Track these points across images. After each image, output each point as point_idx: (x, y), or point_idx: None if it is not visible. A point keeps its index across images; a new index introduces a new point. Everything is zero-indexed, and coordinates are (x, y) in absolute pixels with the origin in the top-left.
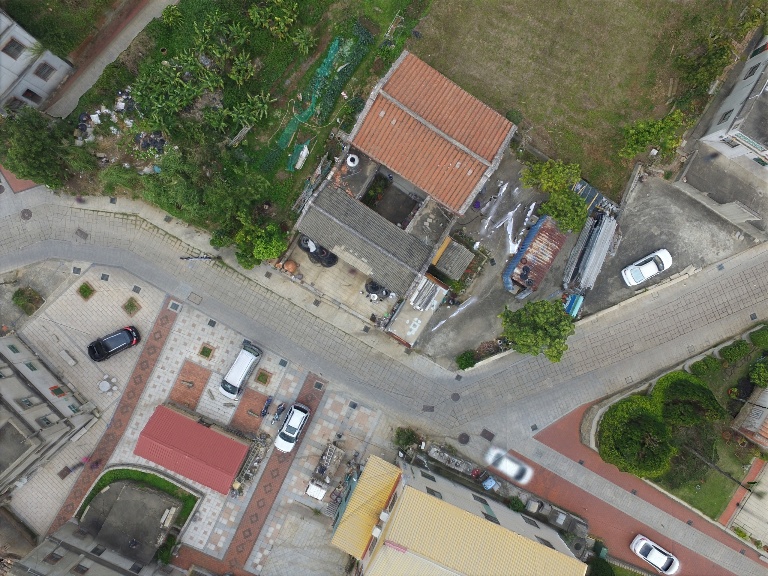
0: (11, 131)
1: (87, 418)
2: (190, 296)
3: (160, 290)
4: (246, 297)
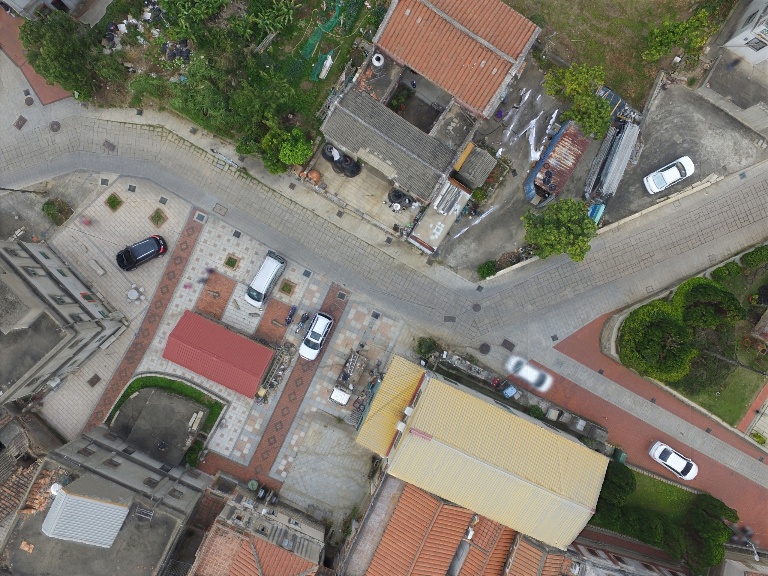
0: (43, 30)
1: (116, 324)
2: (215, 207)
3: (186, 201)
4: (270, 208)
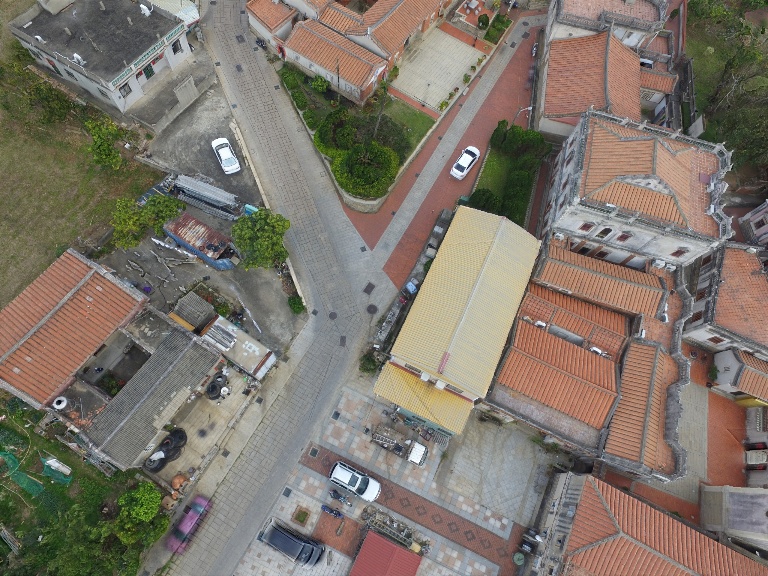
0: None
1: None
2: None
3: None
4: (209, 537)
